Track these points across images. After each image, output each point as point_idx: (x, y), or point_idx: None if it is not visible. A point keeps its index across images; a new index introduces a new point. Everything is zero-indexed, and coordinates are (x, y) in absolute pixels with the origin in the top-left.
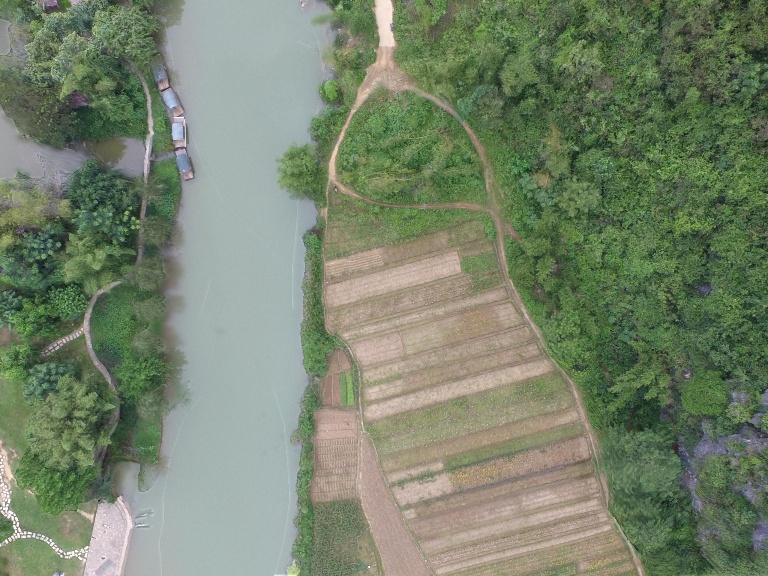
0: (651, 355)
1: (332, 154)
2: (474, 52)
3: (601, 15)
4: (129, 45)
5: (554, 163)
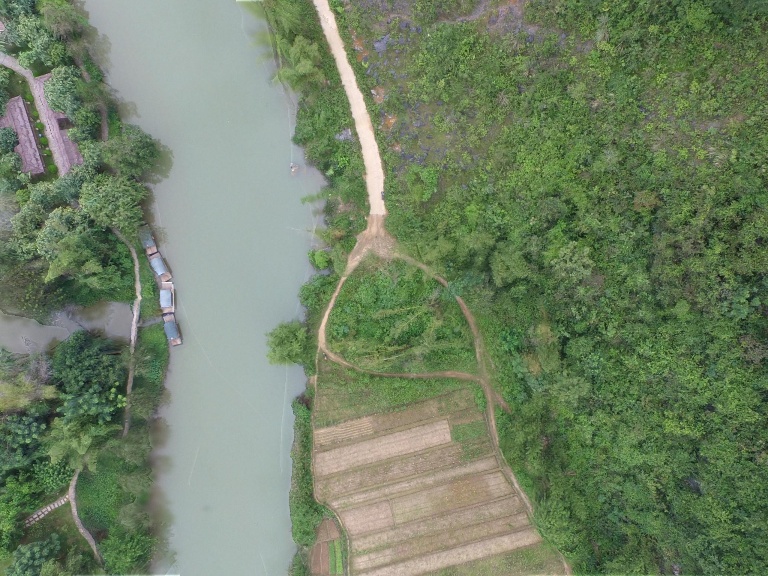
0: (640, 539)
1: (322, 322)
2: (465, 230)
3: (592, 217)
4: (116, 217)
5: (544, 357)
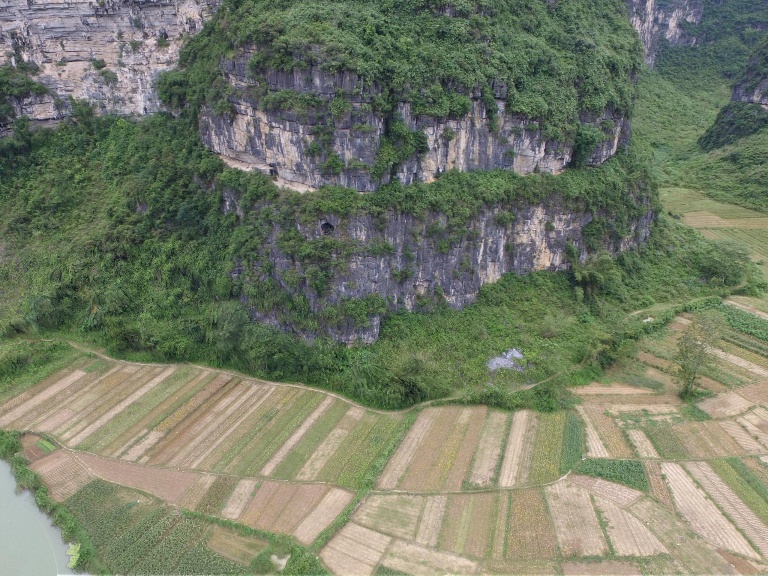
0: None
1: None
2: None
3: None
4: None
5: None
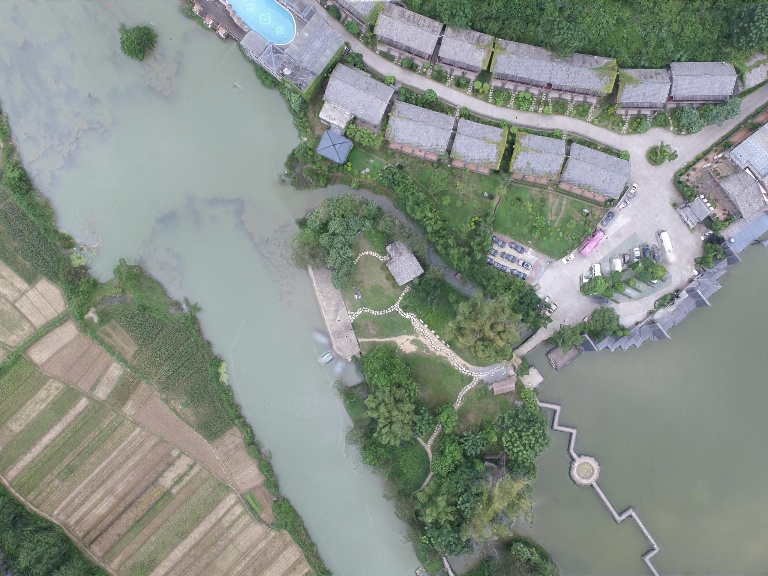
0: None
1: None
2: None
3: None
4: None
5: None
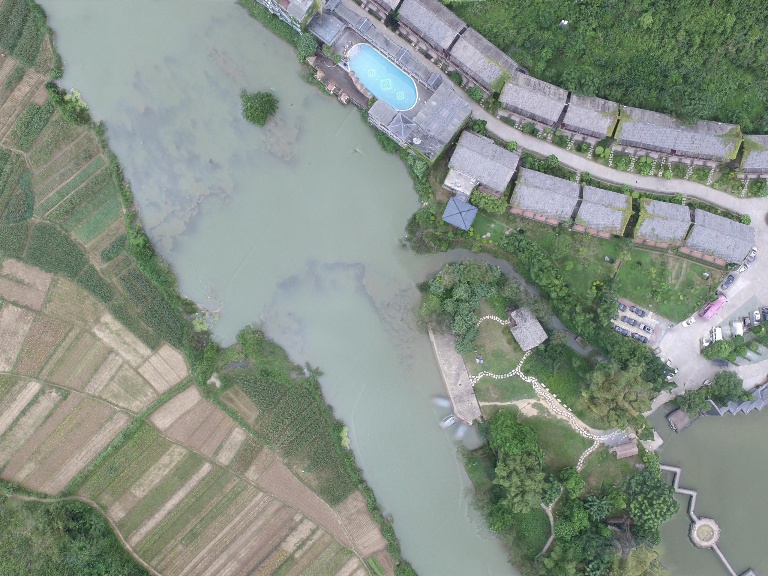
0: None
1: None
2: None
3: None
4: None
5: None
